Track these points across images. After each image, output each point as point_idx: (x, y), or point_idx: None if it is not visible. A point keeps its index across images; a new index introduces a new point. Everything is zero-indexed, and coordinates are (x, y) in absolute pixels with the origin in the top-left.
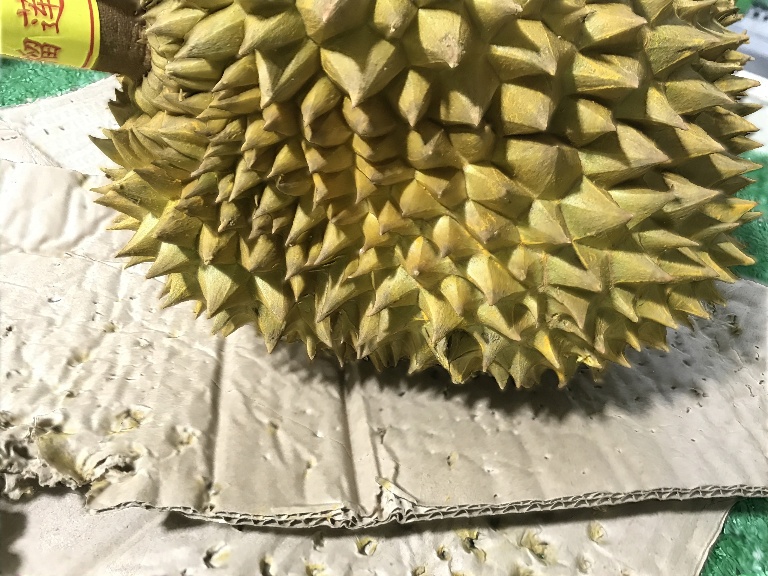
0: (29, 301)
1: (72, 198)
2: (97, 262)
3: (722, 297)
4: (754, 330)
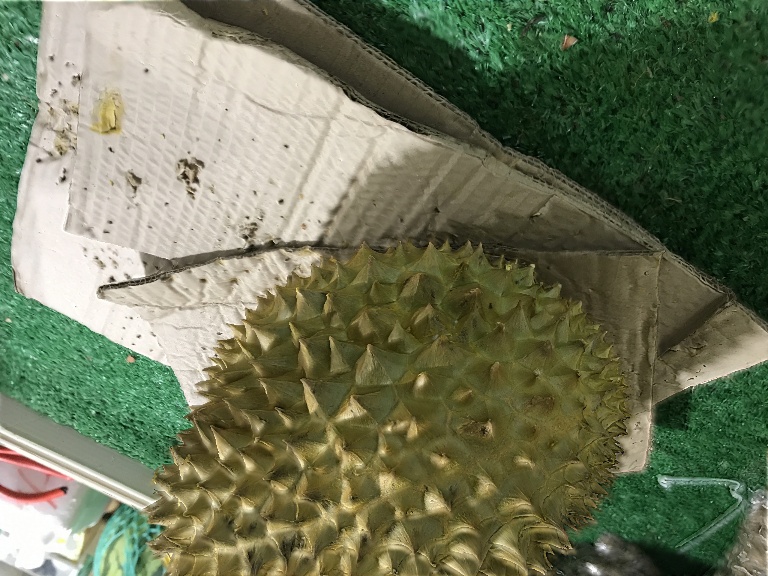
0: (210, 337)
1: (175, 288)
2: (220, 305)
3: (711, 324)
4: (713, 357)
